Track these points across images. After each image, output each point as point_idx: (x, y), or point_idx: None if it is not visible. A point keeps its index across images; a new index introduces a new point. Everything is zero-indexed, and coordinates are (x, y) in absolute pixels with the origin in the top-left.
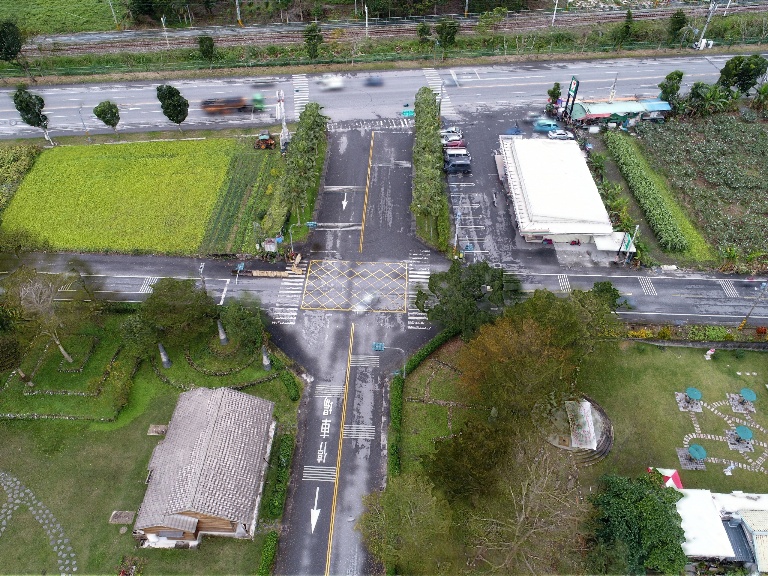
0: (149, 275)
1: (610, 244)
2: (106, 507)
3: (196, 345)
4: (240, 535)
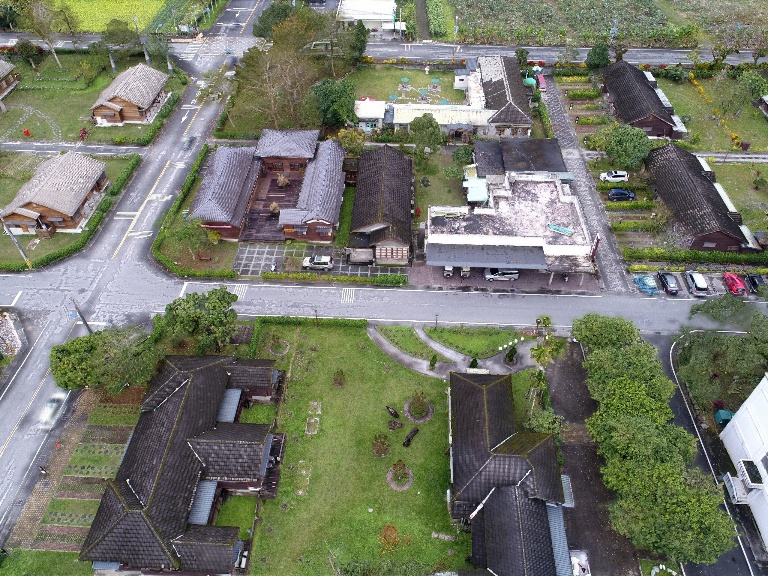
0: None
1: (391, 26)
2: (77, 116)
3: (133, 65)
4: (144, 123)
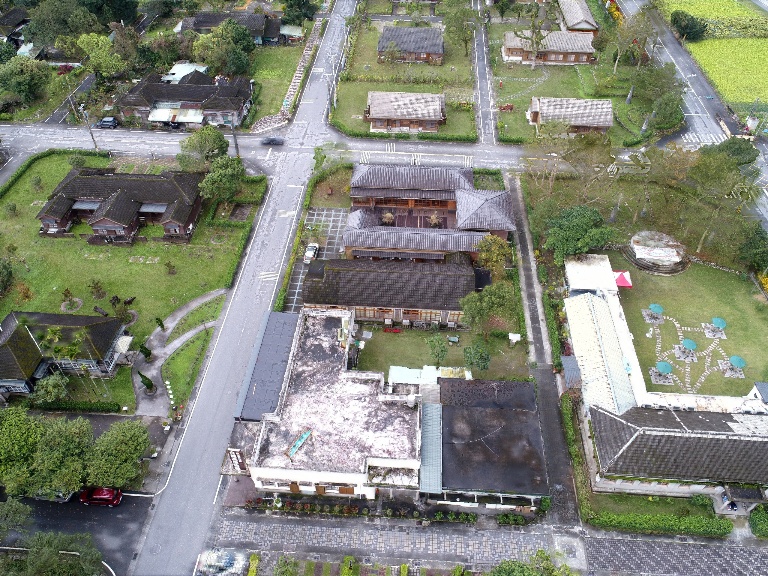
0: (694, 89)
1: None
2: None
3: None
4: None
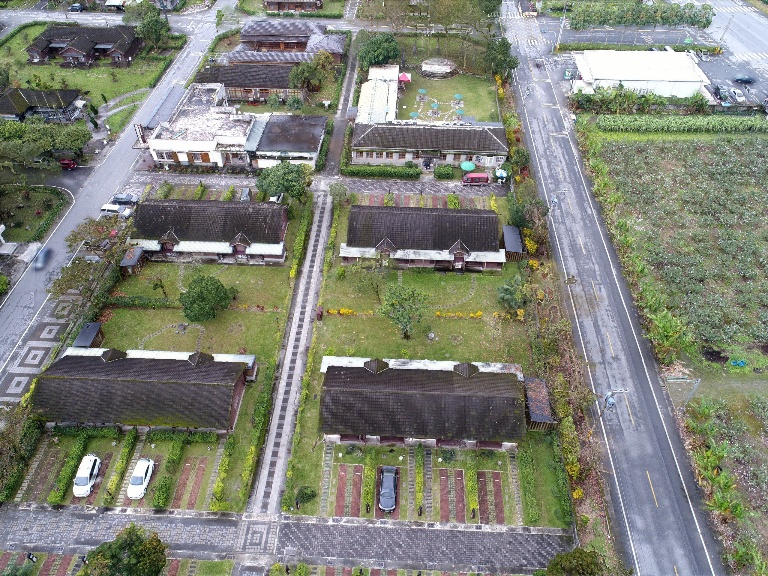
0: None
1: (578, 85)
2: None
3: None
4: None
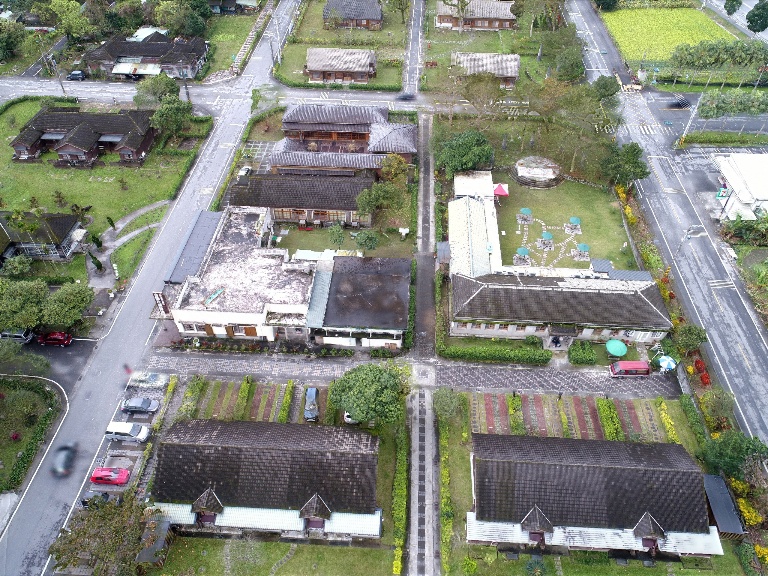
0: (599, 49)
1: None
2: None
3: (554, 65)
4: None
